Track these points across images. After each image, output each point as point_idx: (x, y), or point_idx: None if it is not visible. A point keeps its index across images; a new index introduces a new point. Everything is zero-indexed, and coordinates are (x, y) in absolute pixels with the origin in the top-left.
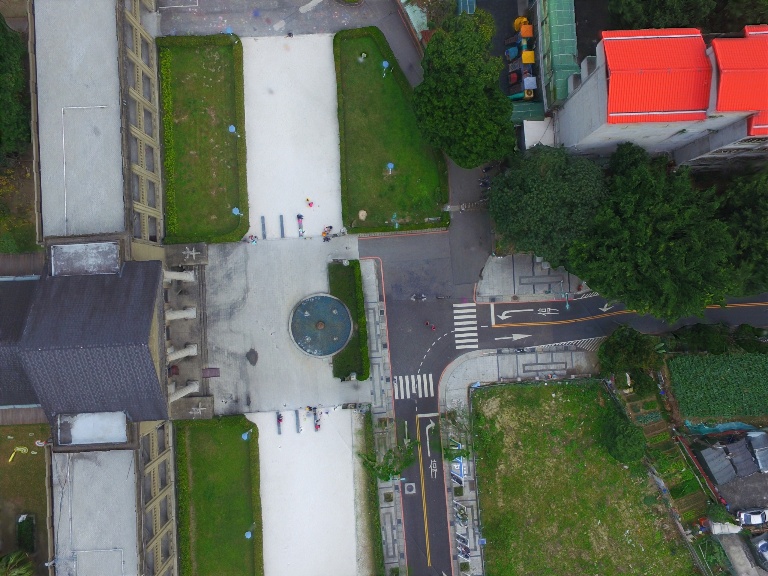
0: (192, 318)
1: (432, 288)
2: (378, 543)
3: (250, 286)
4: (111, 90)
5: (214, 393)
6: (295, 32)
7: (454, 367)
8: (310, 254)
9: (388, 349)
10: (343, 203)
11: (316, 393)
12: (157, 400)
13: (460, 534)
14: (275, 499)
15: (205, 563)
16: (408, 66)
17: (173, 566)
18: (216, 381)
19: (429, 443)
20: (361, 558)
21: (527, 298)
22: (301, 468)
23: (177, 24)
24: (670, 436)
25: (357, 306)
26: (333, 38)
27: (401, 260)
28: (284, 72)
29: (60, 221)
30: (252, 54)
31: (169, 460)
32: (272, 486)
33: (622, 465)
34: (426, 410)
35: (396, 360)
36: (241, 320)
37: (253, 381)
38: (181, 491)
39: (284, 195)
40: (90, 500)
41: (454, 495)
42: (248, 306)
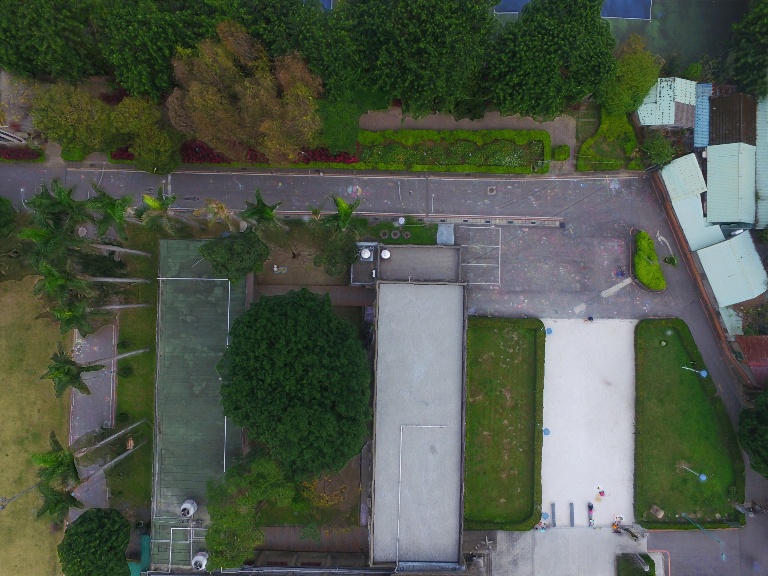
0: None
1: None
2: None
3: (536, 573)
4: (451, 409)
5: None
6: (595, 316)
7: None
8: (598, 544)
9: None
10: (638, 498)
11: None
12: None
13: None
14: None
15: None
16: (708, 358)
17: None
18: None
19: None
20: None
21: None
22: None
23: (478, 301)
24: None
25: None
26: (634, 325)
27: (689, 555)
28: (581, 355)
29: (391, 540)
30: (551, 336)
31: None
32: None
33: None
34: None
35: None
36: None
37: None
38: None
39: (575, 481)
40: None
41: None
42: None
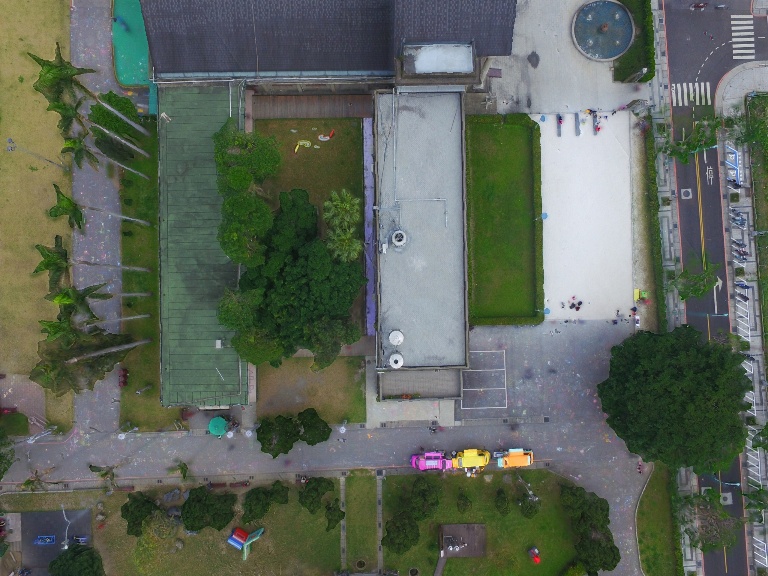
0: None
1: None
2: (659, 242)
3: None
4: None
5: (496, 94)
6: None
7: (731, 77)
8: None
9: (667, 57)
10: None
11: (596, 97)
12: (508, 28)
13: (735, 240)
14: (553, 201)
15: (483, 261)
16: None
17: None
18: (498, 82)
19: (706, 150)
20: (637, 261)
21: None
22: (579, 172)
23: None
24: None
25: (645, 5)
26: None
27: None
28: None
29: None
30: None
31: None
32: (550, 188)
33: None
34: None
35: (674, 68)
36: (523, 23)
37: (534, 83)
38: None
39: None
40: (414, 151)
41: (730, 201)
42: (530, 10)
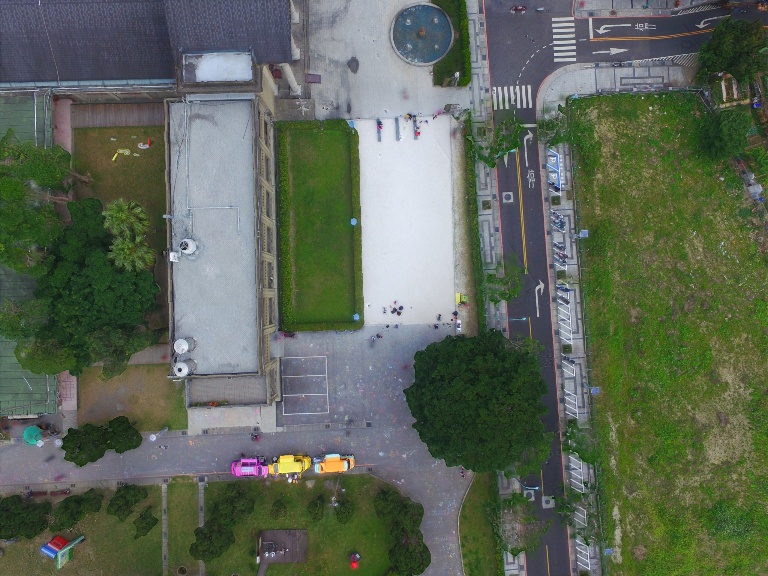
0: (295, 23)
1: (531, 2)
2: (477, 246)
3: None
4: None
5: (315, 99)
6: None
7: (552, 80)
8: None
9: (487, 60)
10: None
11: (416, 102)
12: (284, 35)
13: (557, 243)
14: (374, 206)
15: (304, 267)
16: None
17: (273, 268)
18: (317, 88)
19: (527, 153)
20: (459, 265)
21: (625, 13)
22: (400, 176)
23: None
24: (765, 151)
25: (460, 9)
26: None
27: None
28: None
29: None
30: None
31: (270, 163)
32: (371, 193)
33: (718, 177)
34: (524, 121)
35: (495, 71)
36: (343, 28)
37: (354, 89)
38: (283, 192)
39: None
40: (207, 159)
41: (551, 204)
42: (350, 15)
